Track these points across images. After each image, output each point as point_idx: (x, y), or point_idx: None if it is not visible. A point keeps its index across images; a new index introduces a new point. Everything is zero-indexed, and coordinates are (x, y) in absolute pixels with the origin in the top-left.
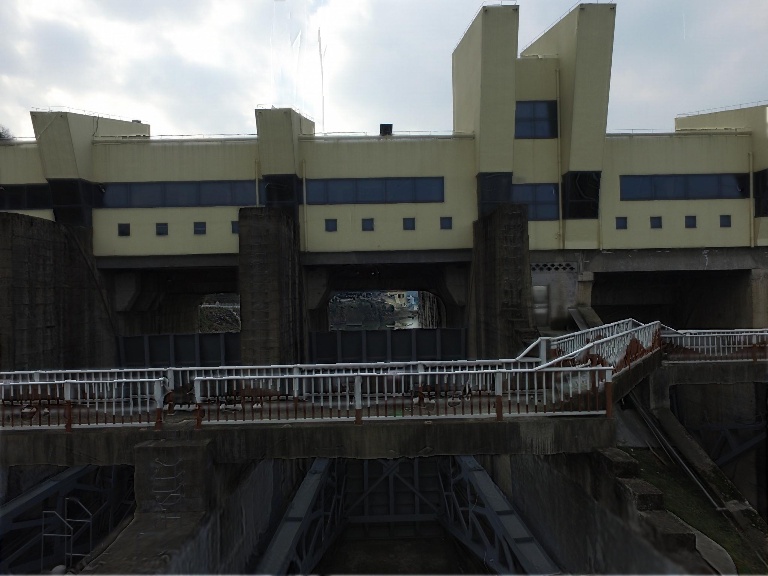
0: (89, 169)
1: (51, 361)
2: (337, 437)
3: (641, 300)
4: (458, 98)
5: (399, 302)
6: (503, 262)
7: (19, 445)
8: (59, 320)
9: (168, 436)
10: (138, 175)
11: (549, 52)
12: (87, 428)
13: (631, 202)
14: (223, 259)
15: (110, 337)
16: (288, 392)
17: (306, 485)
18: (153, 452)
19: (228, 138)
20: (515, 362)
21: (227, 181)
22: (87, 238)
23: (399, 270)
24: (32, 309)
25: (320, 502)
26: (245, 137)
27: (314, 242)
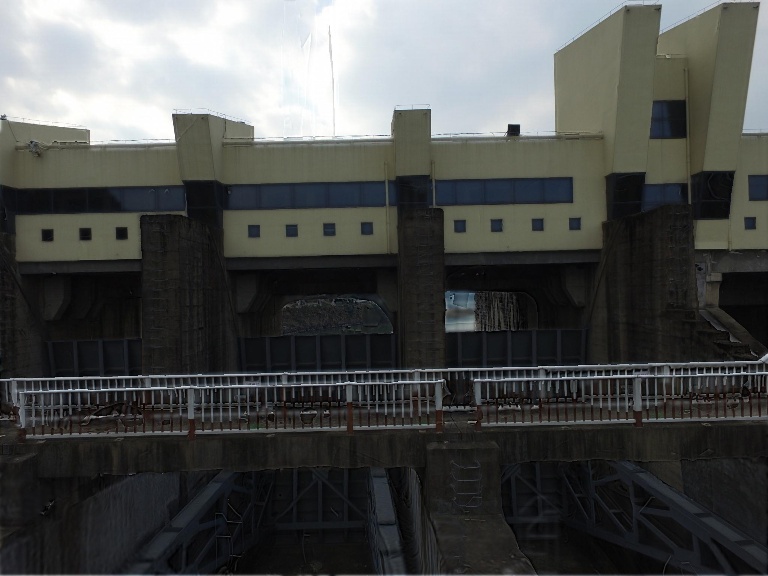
0: (221, 171)
1: (202, 362)
2: (618, 439)
3: (743, 301)
4: (566, 98)
5: None
6: (668, 263)
7: (303, 447)
8: (206, 322)
9: (450, 438)
10: (268, 177)
11: (671, 52)
12: (367, 430)
13: (760, 202)
14: (352, 260)
15: (234, 338)
16: (567, 394)
17: None
18: (448, 454)
19: (357, 139)
20: (761, 364)
21: (356, 182)
22: (220, 240)
23: (506, 271)
24: (191, 311)
25: None
26: (374, 138)
27: None
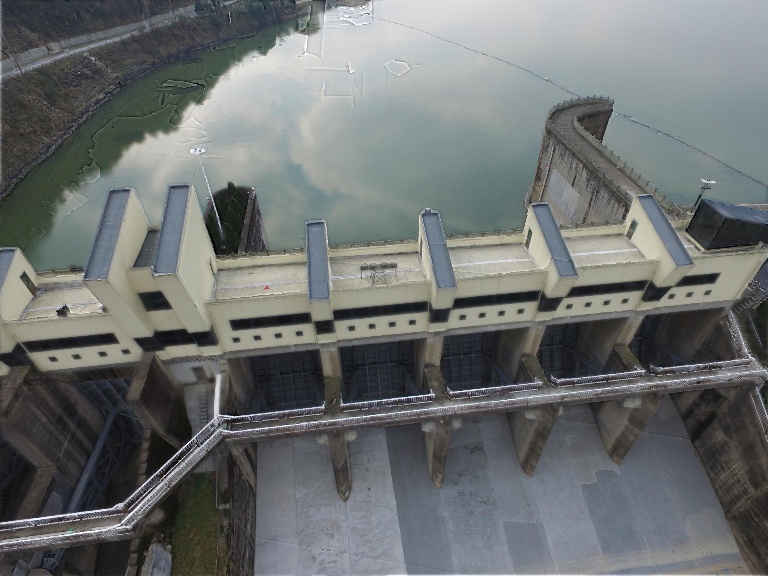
0: None
1: None
2: None
3: None
4: None
5: None
6: None
7: None
8: None
9: None
10: None
11: None
12: None
13: (240, 331)
14: None
15: None
16: (23, 543)
17: (81, 483)
18: None
19: None
20: None
21: None
22: None
23: None
24: None
25: (91, 483)
26: None
27: (47, 367)
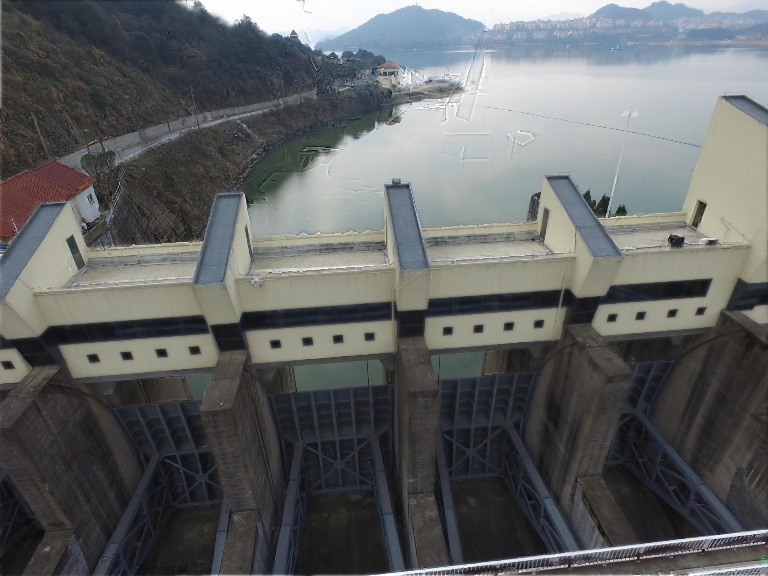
0: None
1: None
2: None
3: None
4: (720, 162)
5: (395, 84)
6: None
7: None
8: None
9: None
10: (462, 291)
11: None
12: None
13: None
14: (521, 344)
15: None
16: None
17: None
18: None
19: (544, 259)
20: None
21: (536, 292)
22: None
23: None
24: None
25: None
26: (558, 257)
27: None
